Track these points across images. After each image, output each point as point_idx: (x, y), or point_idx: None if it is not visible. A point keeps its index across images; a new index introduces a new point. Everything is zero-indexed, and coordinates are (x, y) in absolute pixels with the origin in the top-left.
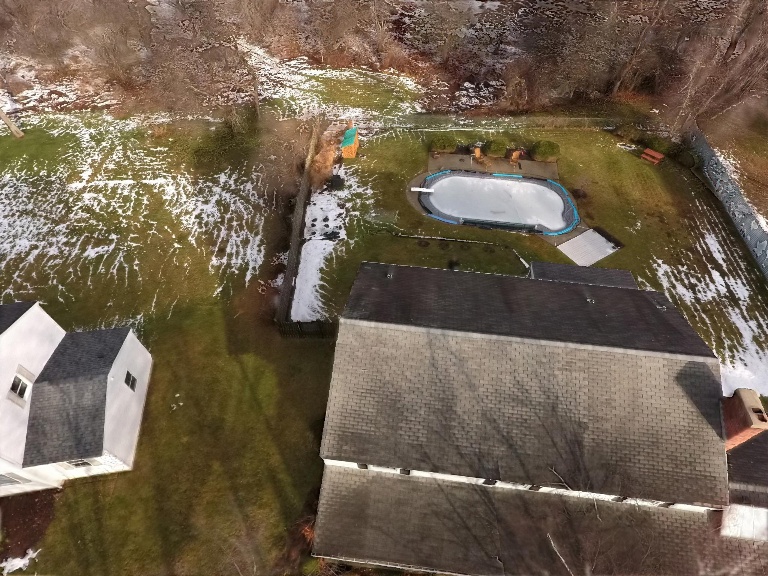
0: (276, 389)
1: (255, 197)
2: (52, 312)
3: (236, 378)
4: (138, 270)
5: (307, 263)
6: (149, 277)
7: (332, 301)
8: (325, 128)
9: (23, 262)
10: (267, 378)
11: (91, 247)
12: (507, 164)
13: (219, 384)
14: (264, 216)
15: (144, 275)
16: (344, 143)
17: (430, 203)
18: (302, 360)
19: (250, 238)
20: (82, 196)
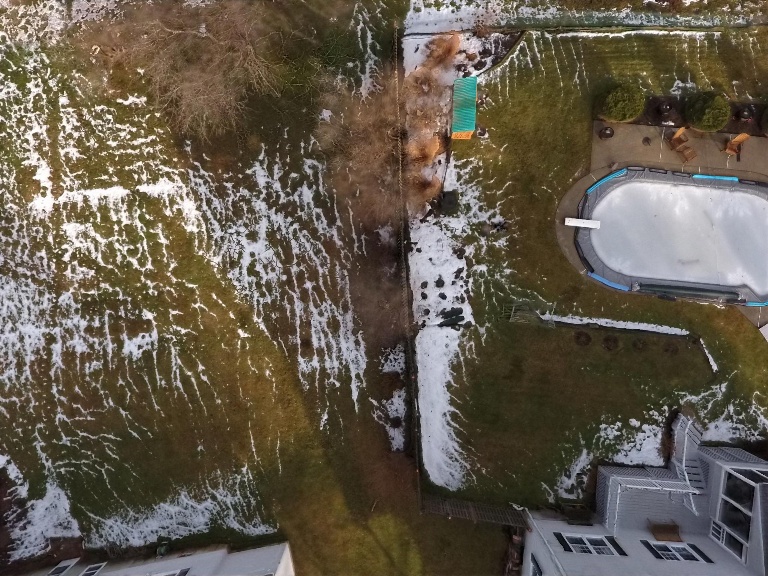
0: (427, 565)
1: (323, 223)
2: (135, 456)
3: (380, 549)
4: (209, 383)
5: (428, 372)
6: (229, 398)
7: (471, 444)
8: (401, 24)
9: (51, 368)
10: (414, 550)
11: (127, 337)
12: (719, 148)
13: (365, 559)
14: (347, 269)
15: (221, 395)
16: (456, 122)
17: (592, 249)
18: (449, 531)
19: (338, 317)
20: (63, 231)
